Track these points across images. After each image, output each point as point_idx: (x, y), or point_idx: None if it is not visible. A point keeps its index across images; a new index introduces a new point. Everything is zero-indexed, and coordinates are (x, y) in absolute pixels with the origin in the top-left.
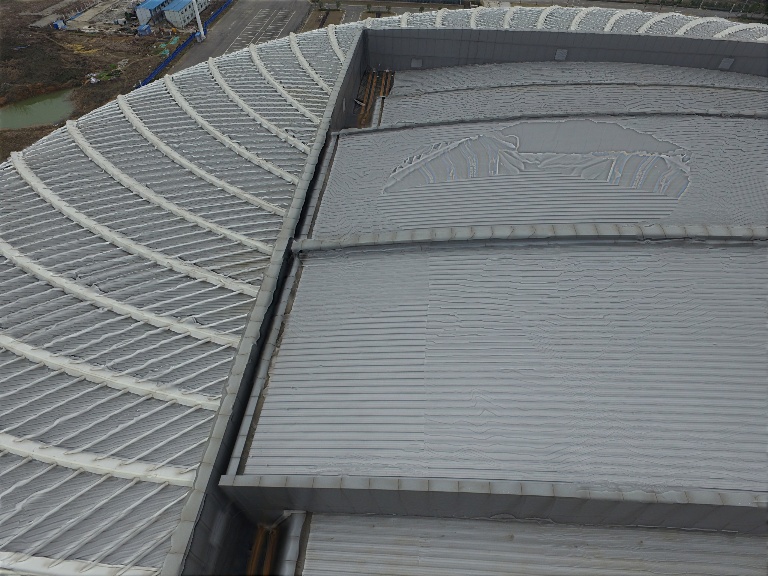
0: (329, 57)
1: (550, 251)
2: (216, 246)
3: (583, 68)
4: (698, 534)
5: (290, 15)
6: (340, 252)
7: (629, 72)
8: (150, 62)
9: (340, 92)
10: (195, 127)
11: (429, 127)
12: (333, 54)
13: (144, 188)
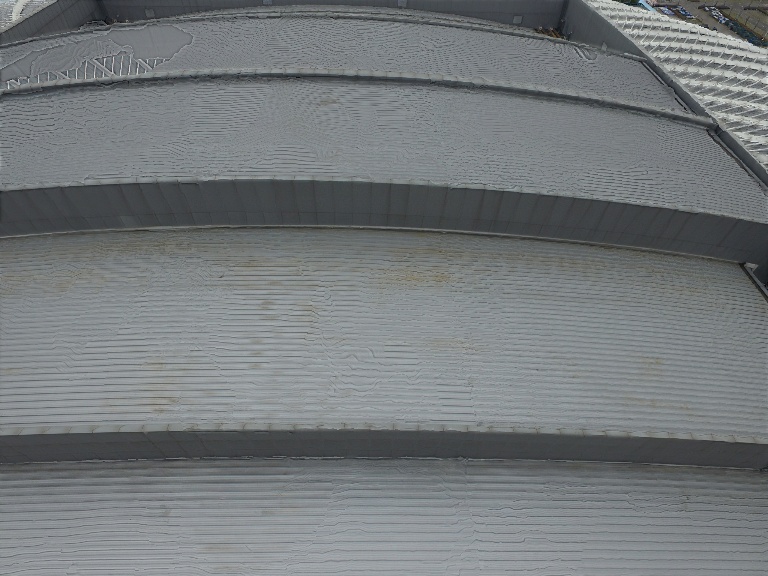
0: (43, 4)
1: (47, 100)
2: None
3: (284, 10)
4: (37, 238)
5: None
6: None
7: None
8: None
9: (22, 26)
10: None
11: (50, 39)
12: None
13: None
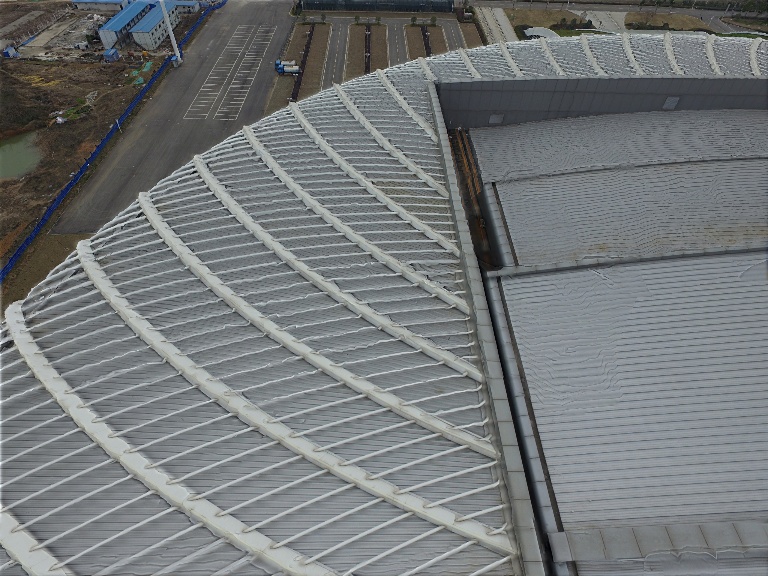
0: (411, 128)
1: None
2: (407, 541)
3: (700, 119)
4: None
5: (272, 31)
6: (642, 564)
7: (754, 122)
8: (123, 94)
9: None
10: (276, 263)
11: (633, 264)
12: (413, 123)
13: (241, 401)
